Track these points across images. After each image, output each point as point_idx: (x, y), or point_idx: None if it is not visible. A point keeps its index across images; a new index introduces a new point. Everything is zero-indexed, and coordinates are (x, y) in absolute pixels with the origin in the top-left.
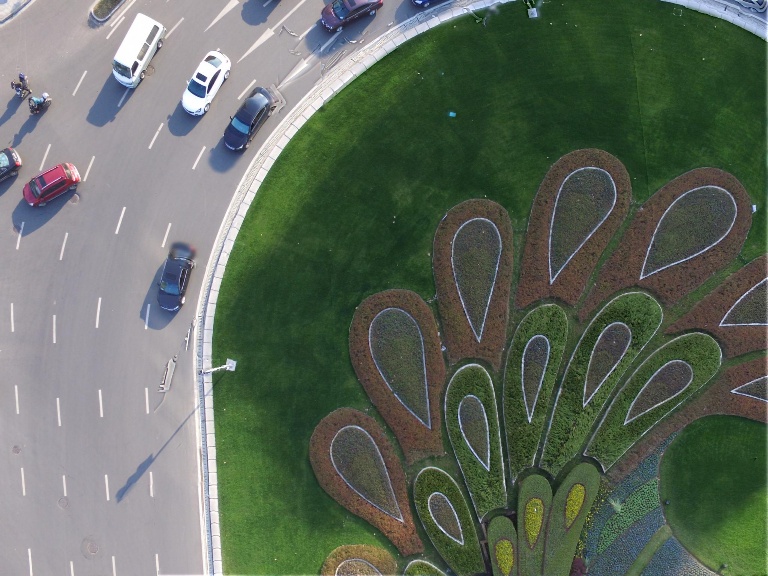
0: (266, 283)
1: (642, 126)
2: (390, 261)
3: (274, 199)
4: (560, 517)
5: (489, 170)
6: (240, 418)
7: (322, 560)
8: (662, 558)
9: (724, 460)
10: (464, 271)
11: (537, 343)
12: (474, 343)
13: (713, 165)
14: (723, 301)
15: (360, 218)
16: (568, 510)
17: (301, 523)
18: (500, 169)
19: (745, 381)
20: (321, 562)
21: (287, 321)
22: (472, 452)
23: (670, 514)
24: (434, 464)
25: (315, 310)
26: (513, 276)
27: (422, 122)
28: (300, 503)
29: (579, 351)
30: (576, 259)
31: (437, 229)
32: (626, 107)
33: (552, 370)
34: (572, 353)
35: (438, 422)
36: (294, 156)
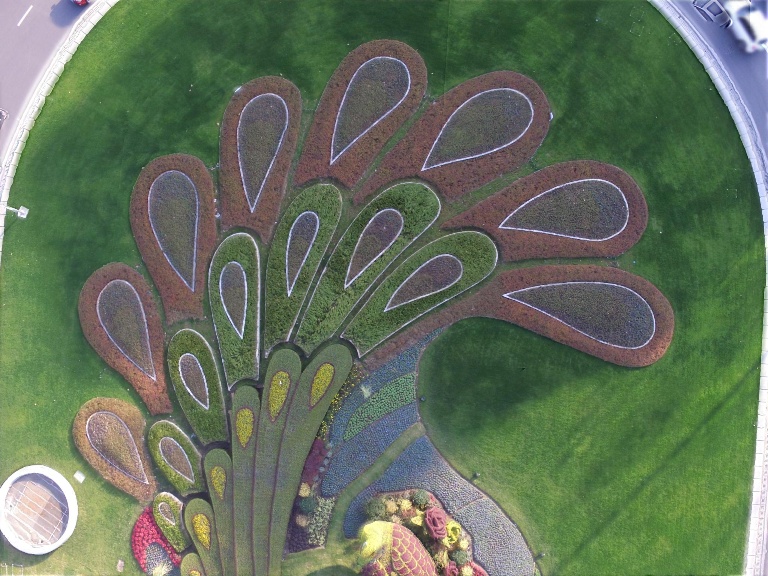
0: (66, 137)
1: (448, 24)
2: (181, 127)
3: (87, 60)
4: (305, 394)
5: (289, 50)
6: (23, 263)
7: (77, 410)
8: (411, 455)
9: (489, 365)
10: (247, 142)
11: (306, 218)
12: (246, 212)
13: (516, 70)
14: (505, 203)
15: (160, 84)
16: (314, 388)
17: (63, 371)
18: (299, 50)
19: (519, 287)
20: (76, 411)
21: (79, 174)
22: (228, 318)
23: (425, 412)
24: (192, 327)
25: (105, 166)
26: (295, 153)
27: (233, 0)
28: (64, 351)
29: (348, 232)
30: (359, 143)
31: (230, 101)
32: (435, 5)
33: (318, 248)
34: (342, 234)
35: (201, 285)
36: (112, 22)
